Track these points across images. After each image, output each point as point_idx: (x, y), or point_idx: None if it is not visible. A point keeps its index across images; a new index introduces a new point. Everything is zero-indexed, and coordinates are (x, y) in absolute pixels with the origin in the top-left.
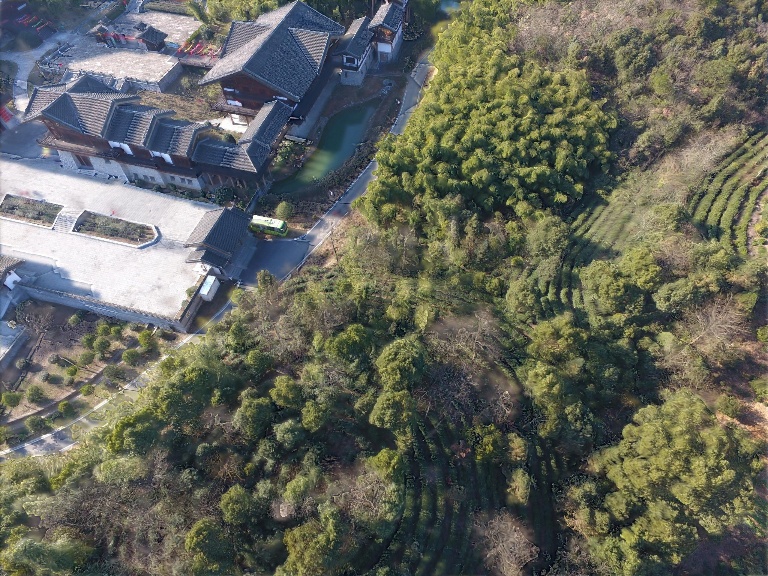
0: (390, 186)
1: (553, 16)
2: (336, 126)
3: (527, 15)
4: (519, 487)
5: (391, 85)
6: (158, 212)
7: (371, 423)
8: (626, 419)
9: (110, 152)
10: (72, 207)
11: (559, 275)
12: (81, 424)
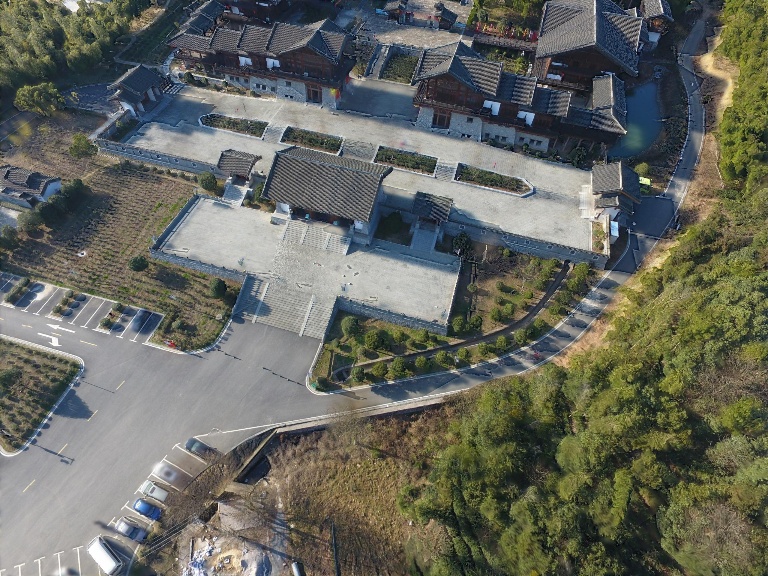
0: None
1: None
2: None
3: None
4: None
5: (660, 71)
6: (519, 168)
7: None
8: None
9: None
10: (446, 159)
11: None
12: (551, 340)
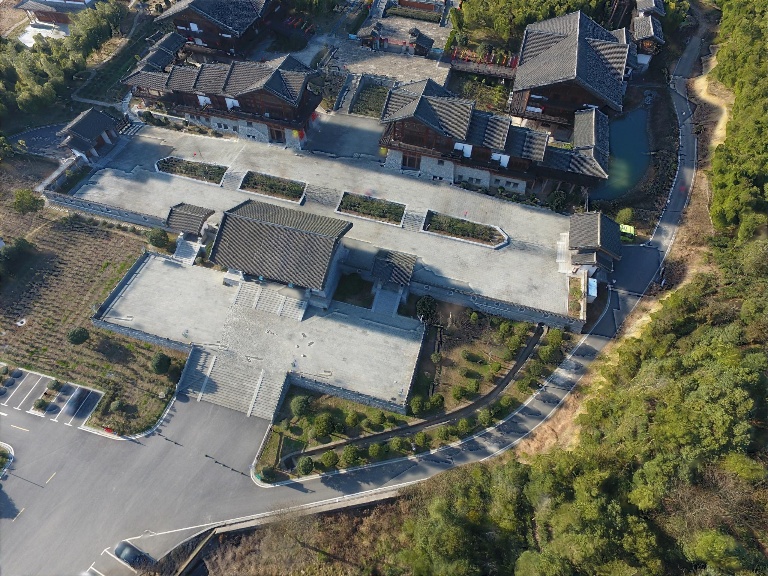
0: None
1: None
2: None
3: None
4: None
5: (651, 96)
6: (494, 214)
7: None
8: None
9: (453, 154)
10: (414, 206)
11: None
12: (520, 419)
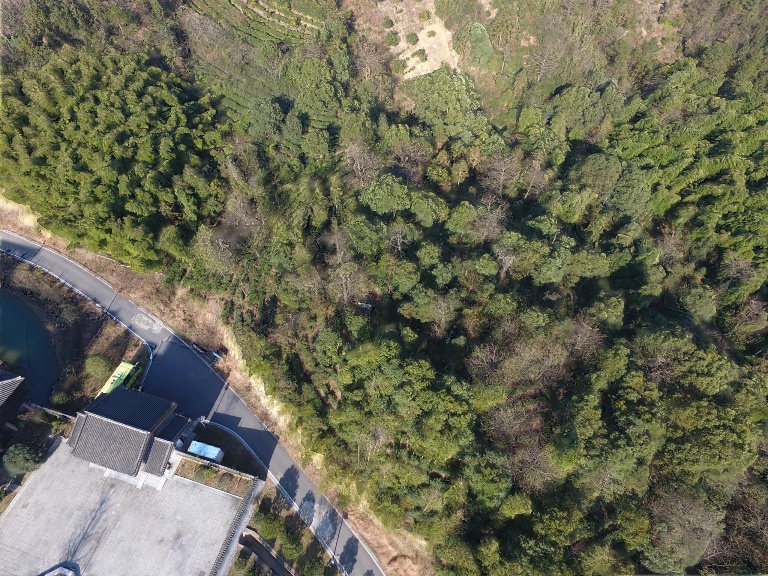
0: None
1: None
2: None
3: None
4: (463, 171)
5: None
6: None
7: (432, 223)
8: (415, 123)
9: None
10: None
11: None
12: None
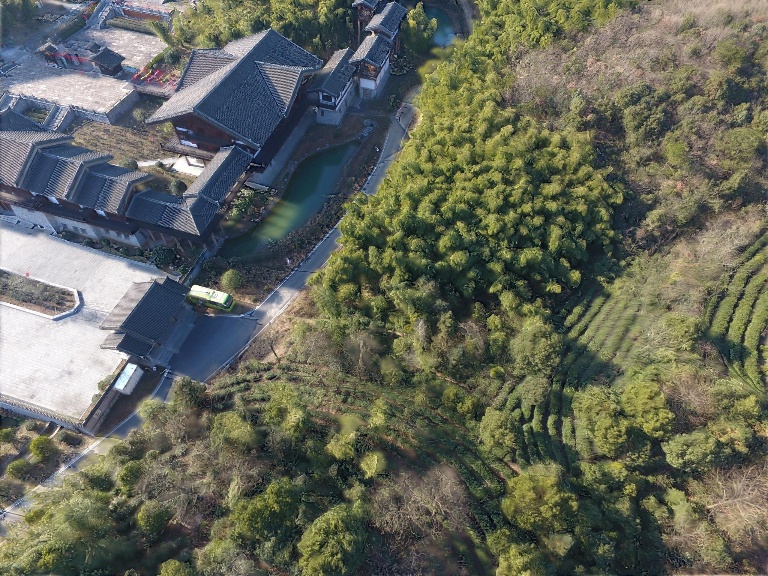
0: (354, 262)
1: (555, 62)
2: (308, 170)
3: (526, 59)
4: None
5: (373, 126)
6: (85, 273)
7: None
8: None
9: (31, 201)
10: None
11: (547, 396)
12: None
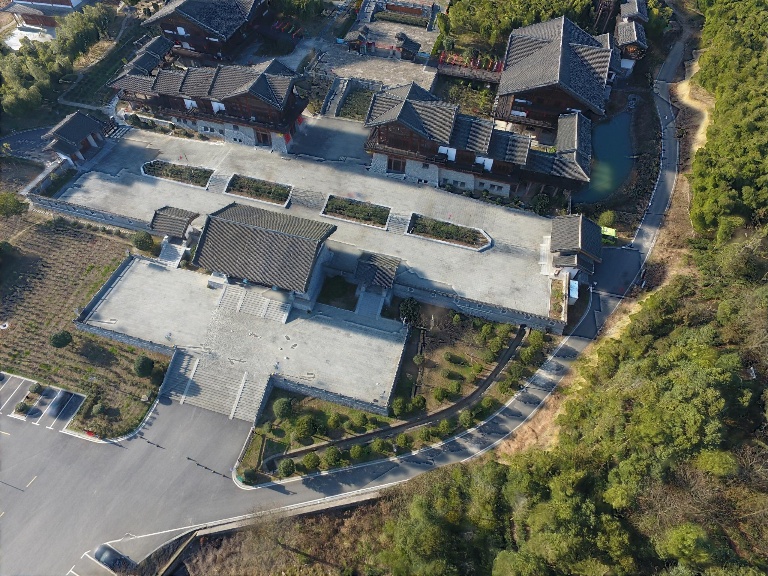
0: None
1: None
2: None
3: None
4: None
5: (635, 100)
6: (478, 217)
7: None
8: None
9: None
10: (399, 209)
11: None
12: (501, 419)
